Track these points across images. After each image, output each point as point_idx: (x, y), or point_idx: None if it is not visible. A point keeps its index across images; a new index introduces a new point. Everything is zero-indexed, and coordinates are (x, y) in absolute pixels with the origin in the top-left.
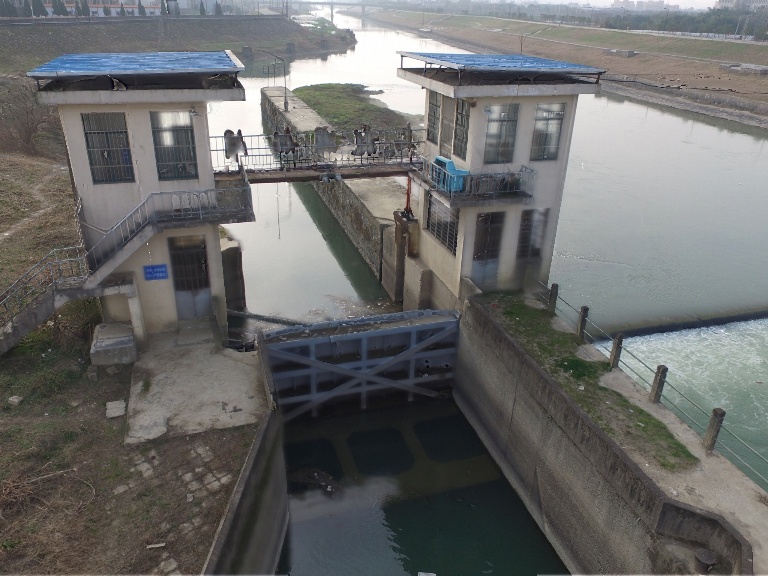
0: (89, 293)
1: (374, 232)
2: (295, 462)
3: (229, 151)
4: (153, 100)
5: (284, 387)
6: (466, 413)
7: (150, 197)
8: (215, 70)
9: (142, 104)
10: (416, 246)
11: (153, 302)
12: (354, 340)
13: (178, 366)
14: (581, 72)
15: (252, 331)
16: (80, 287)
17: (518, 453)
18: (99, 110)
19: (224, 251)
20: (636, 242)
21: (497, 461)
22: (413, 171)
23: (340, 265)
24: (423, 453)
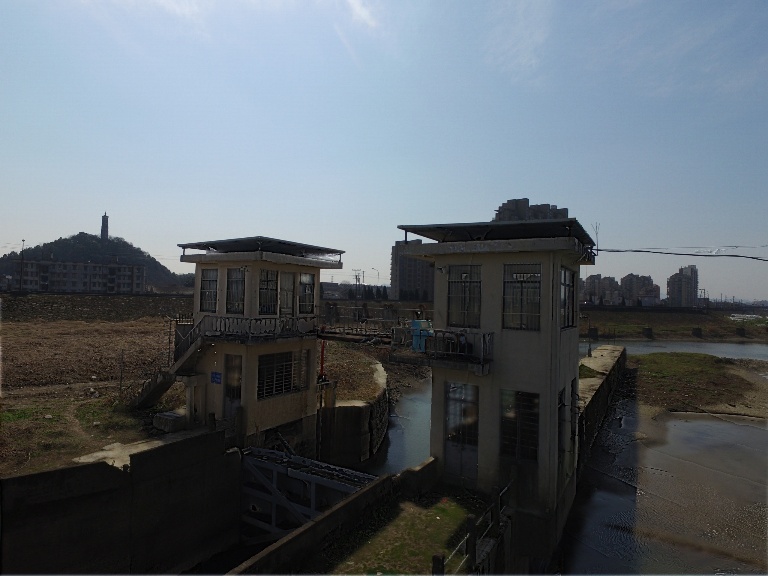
0: (170, 377)
1: None
2: (204, 574)
3: (327, 317)
4: (221, 259)
5: (266, 511)
6: None
7: (204, 318)
8: (246, 239)
9: (225, 264)
10: None
11: (212, 400)
12: None
13: None
14: (537, 224)
15: None
16: (168, 371)
17: None
18: (208, 267)
19: (348, 407)
20: None
21: None
22: None
23: None
24: None
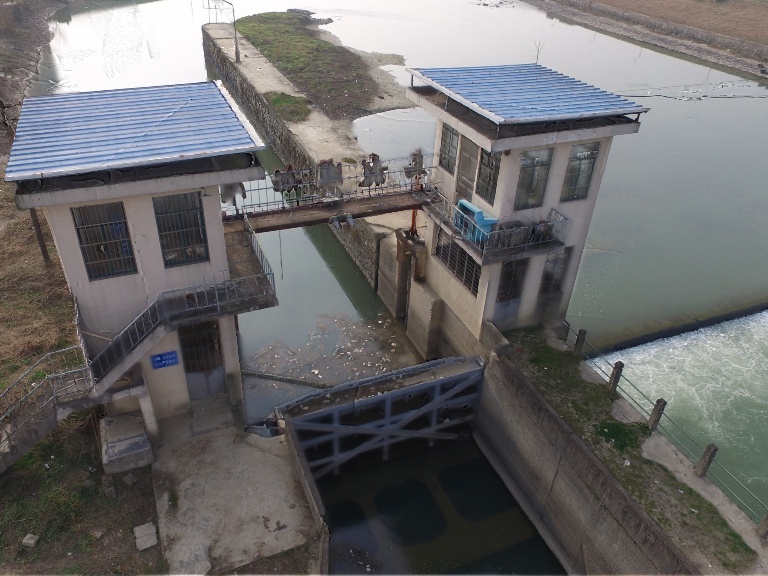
0: (96, 401)
1: (367, 239)
2: None
3: (225, 195)
4: (158, 190)
5: (304, 449)
6: (490, 459)
7: (161, 297)
8: (231, 152)
9: None
10: (423, 270)
11: (162, 388)
12: (378, 401)
13: (202, 466)
14: (622, 113)
15: (252, 369)
16: (85, 397)
17: (559, 522)
18: (92, 202)
19: None
20: (621, 221)
21: (530, 518)
22: (427, 204)
23: (320, 253)
24: (453, 510)
